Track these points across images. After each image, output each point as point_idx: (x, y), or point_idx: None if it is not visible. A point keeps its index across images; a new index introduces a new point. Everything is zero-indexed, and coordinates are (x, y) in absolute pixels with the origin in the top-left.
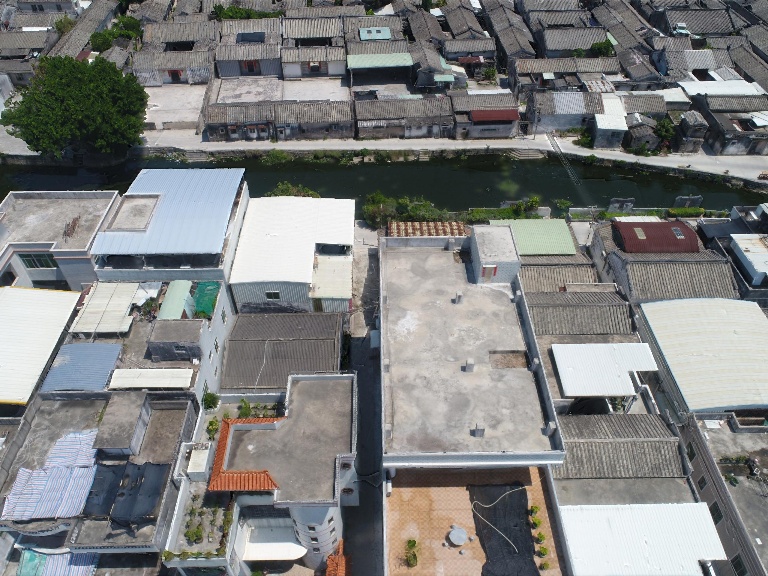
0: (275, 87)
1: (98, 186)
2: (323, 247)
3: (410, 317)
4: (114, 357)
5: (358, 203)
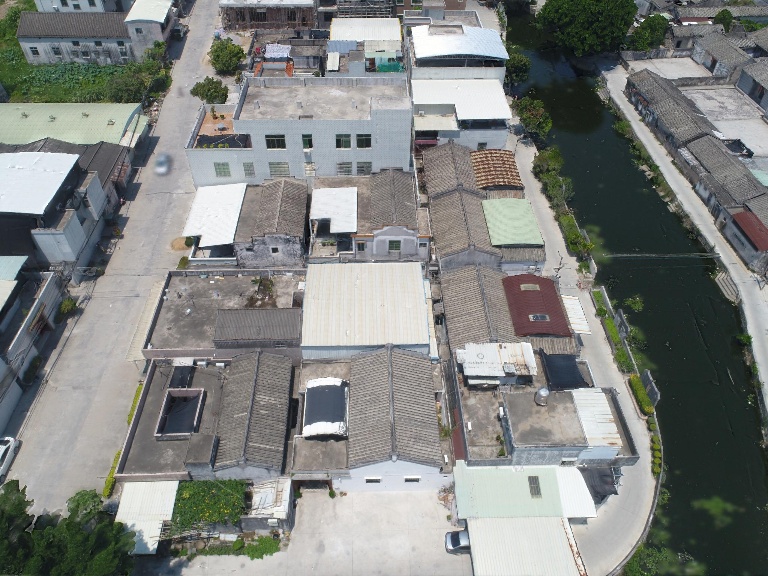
0: (743, 114)
1: (550, 66)
2: (474, 125)
3: (342, 93)
4: (348, 52)
5: (576, 170)
